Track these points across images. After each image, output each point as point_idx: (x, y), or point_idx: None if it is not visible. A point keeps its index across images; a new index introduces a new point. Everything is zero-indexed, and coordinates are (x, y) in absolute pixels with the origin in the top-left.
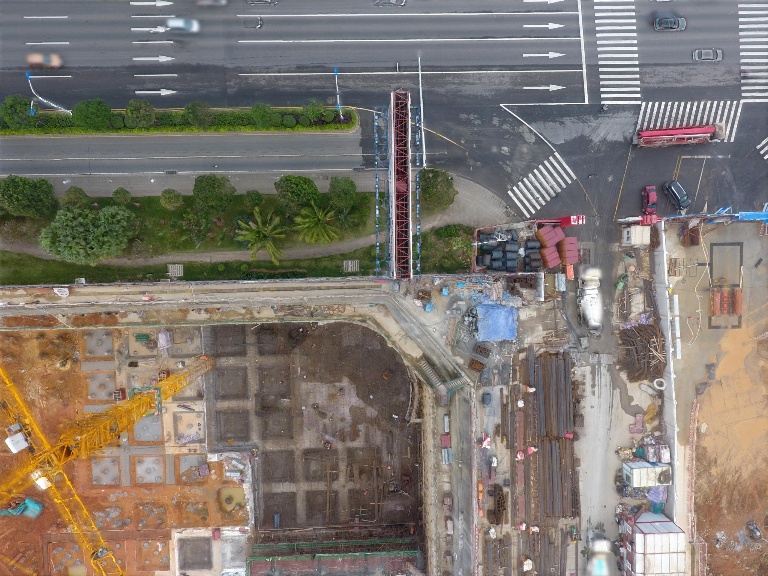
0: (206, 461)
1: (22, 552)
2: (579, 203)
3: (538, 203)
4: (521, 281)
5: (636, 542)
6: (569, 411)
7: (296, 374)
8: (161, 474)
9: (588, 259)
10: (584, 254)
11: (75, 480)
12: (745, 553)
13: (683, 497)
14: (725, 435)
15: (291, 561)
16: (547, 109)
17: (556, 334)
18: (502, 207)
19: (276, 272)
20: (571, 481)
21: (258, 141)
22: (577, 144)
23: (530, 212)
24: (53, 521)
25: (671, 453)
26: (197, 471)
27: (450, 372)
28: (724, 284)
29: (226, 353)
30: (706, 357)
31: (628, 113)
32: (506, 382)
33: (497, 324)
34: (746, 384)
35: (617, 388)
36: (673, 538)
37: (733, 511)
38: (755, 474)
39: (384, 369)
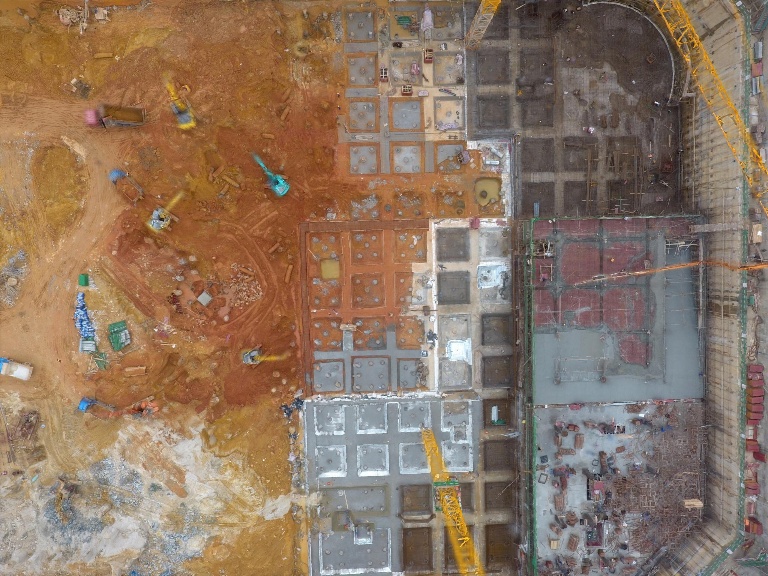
0: (465, 149)
1: (279, 242)
2: None
3: None
4: None
5: None
6: None
7: (558, 59)
8: (418, 164)
9: None
10: None
11: (335, 167)
12: None
13: None
14: None
15: (573, 224)
16: None
17: None
18: None
19: None
20: None
21: None
22: None
23: None
24: (311, 210)
25: None
26: (454, 161)
27: None
28: None
29: (488, 36)
30: None
31: None
32: None
33: None
34: None
35: None
36: None
37: None
38: None
39: (647, 53)
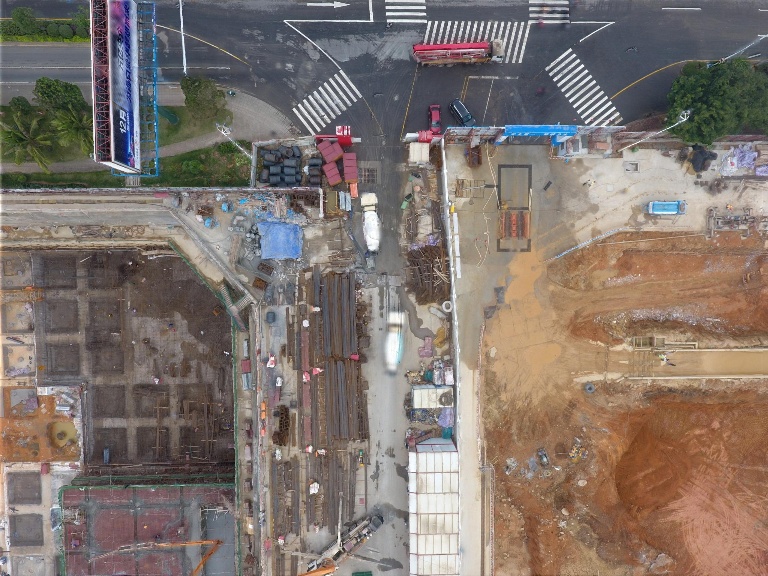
0: (36, 395)
1: None
2: (365, 122)
3: (323, 121)
4: (302, 198)
5: (409, 461)
6: (353, 331)
7: (127, 308)
8: None
9: (375, 179)
10: (371, 174)
11: None
12: (536, 481)
13: (472, 422)
14: (515, 360)
15: (105, 491)
16: (331, 26)
17: (342, 254)
18: (287, 124)
19: (54, 184)
20: (357, 403)
21: (38, 52)
22: (362, 62)
23: (315, 130)
24: None
25: (455, 375)
26: None
27: (241, 293)
28: (512, 206)
29: (56, 286)
30: (495, 280)
31: (414, 32)
32: (291, 301)
33: (276, 240)
34: (536, 309)
35: (406, 310)
36: (446, 457)
37: (523, 438)
38: (546, 400)
39: (215, 305)
